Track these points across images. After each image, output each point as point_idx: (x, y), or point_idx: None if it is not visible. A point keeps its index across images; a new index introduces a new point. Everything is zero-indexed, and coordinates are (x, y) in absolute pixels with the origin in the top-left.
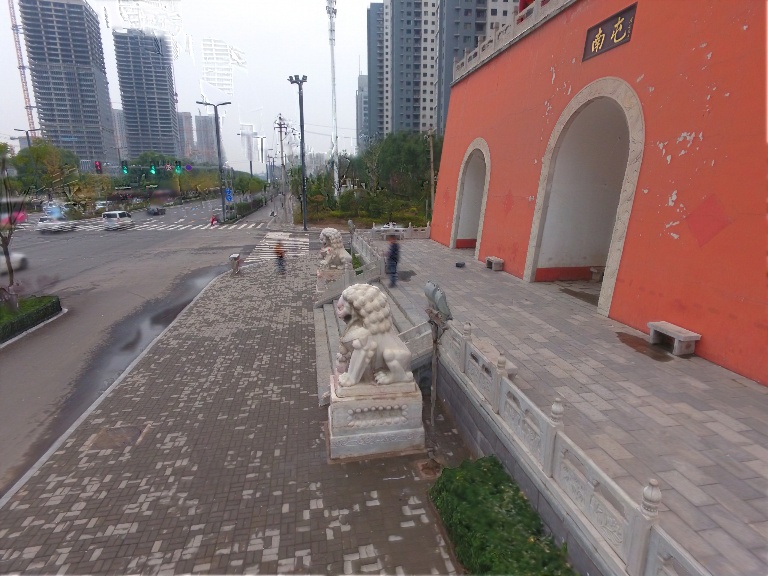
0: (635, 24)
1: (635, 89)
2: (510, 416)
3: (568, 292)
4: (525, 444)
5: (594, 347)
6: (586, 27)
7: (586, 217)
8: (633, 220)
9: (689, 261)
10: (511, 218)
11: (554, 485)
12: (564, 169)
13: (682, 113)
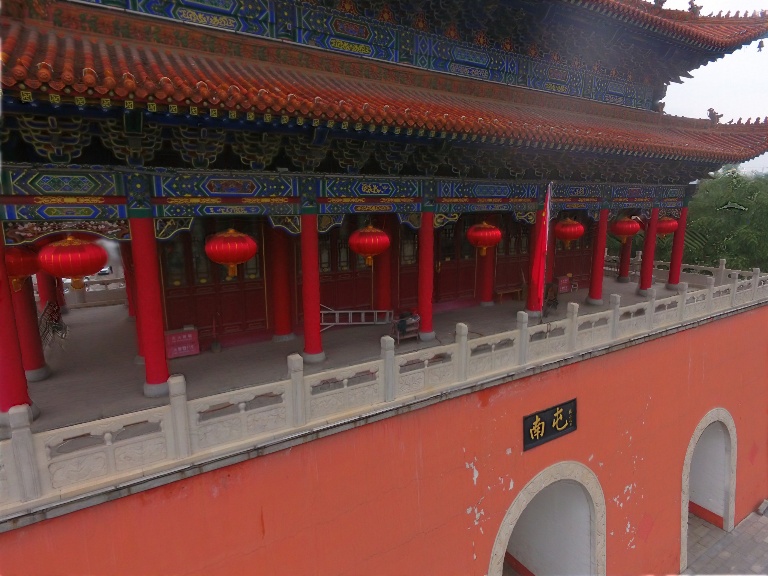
0: (579, 416)
1: (590, 467)
2: None
3: None
4: None
5: None
6: (520, 414)
7: None
8: None
9: (642, 554)
10: None
11: None
12: None
13: None
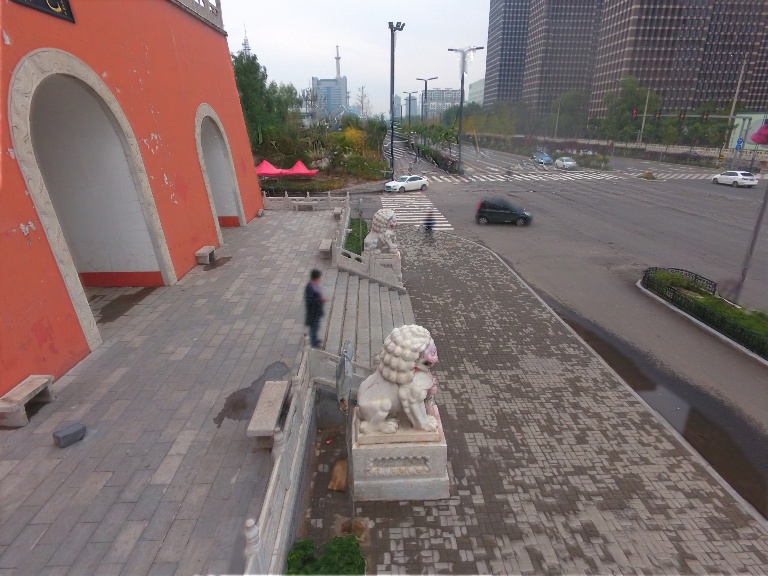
0: None
1: (106, 84)
2: None
3: (116, 315)
4: (342, 237)
5: (247, 263)
6: None
7: None
8: None
9: None
10: None
11: None
12: None
13: None
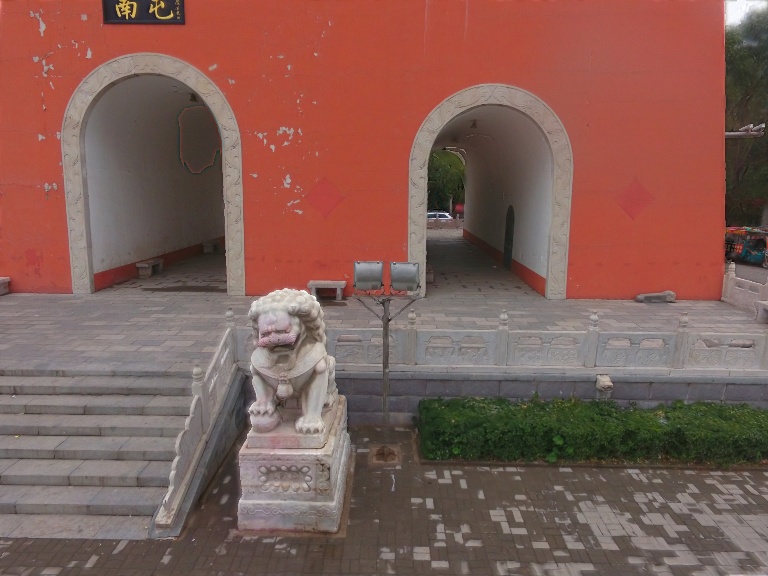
0: (187, 9)
1: (209, 77)
2: (437, 356)
3: (157, 290)
4: (466, 364)
5: None
6: None
7: (121, 208)
8: (248, 202)
9: (318, 230)
10: (3, 216)
11: (515, 366)
12: (93, 150)
13: (274, 110)
